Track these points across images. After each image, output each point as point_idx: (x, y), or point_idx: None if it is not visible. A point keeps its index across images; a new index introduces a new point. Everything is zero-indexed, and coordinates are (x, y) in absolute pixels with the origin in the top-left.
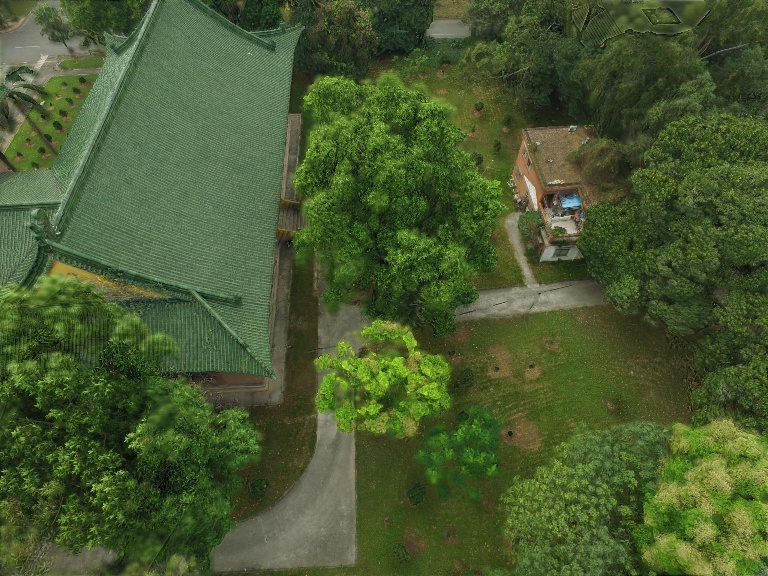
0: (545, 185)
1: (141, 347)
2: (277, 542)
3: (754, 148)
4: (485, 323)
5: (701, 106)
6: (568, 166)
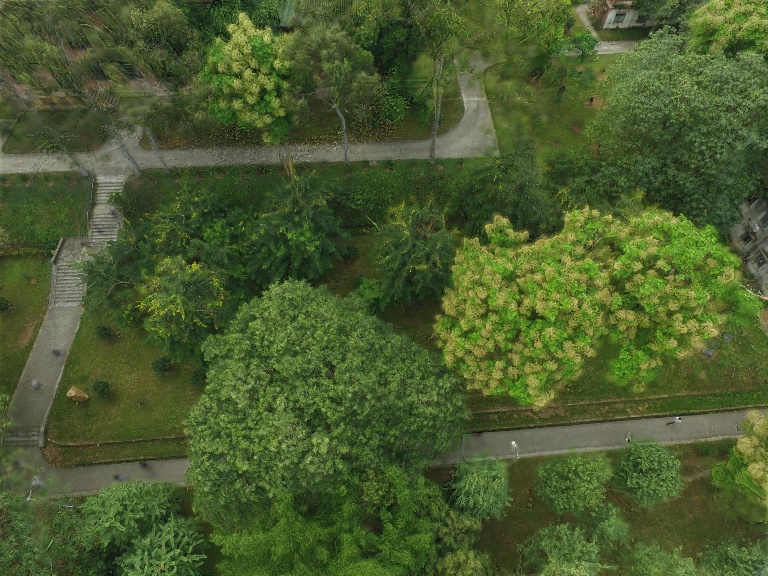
0: None
1: (380, 8)
2: (450, 148)
3: None
4: (568, 58)
5: None
6: None
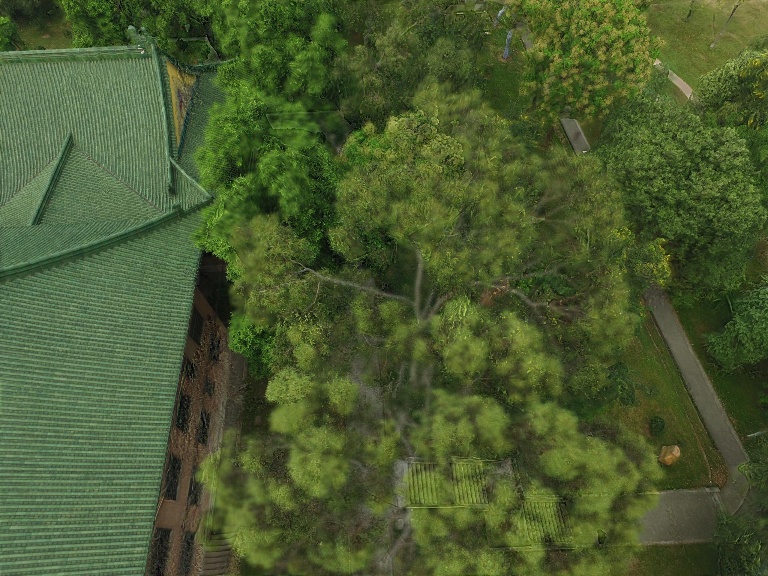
0: None
1: (226, 113)
2: None
3: None
4: None
5: None
6: None
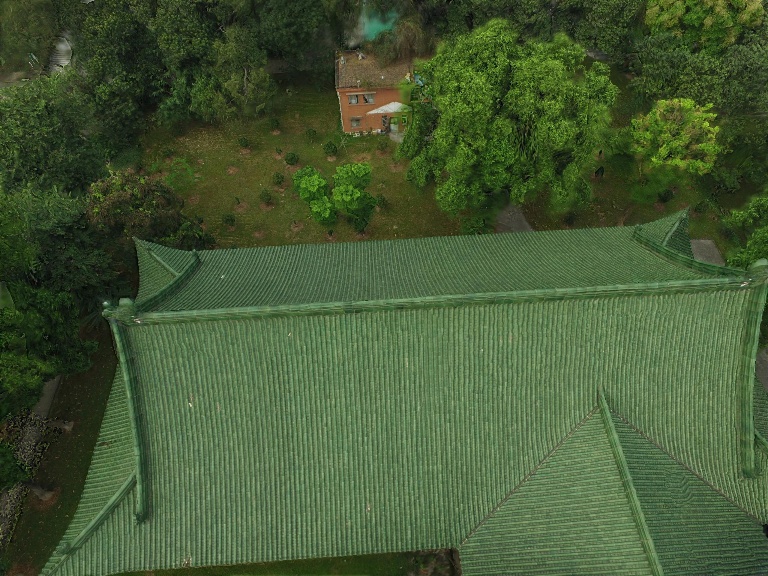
0: (411, 84)
1: None
2: None
3: None
4: None
5: None
6: (389, 69)
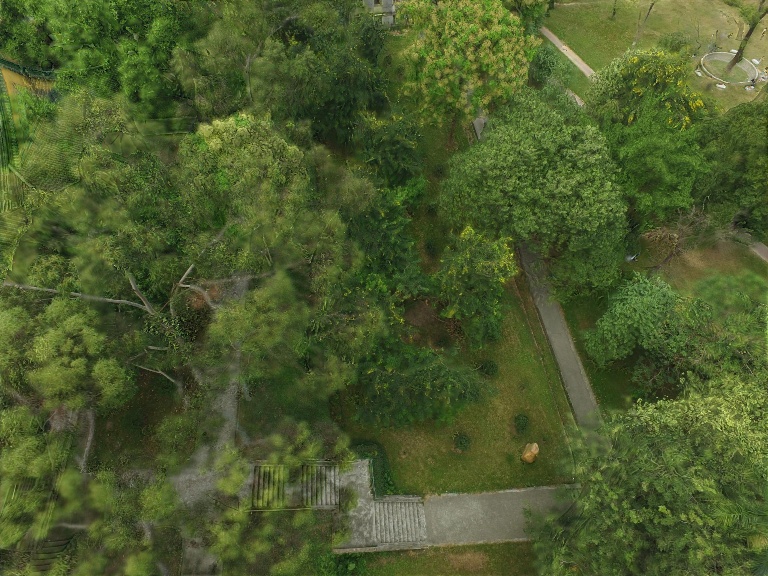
0: None
1: None
2: None
3: None
4: None
5: None
6: None
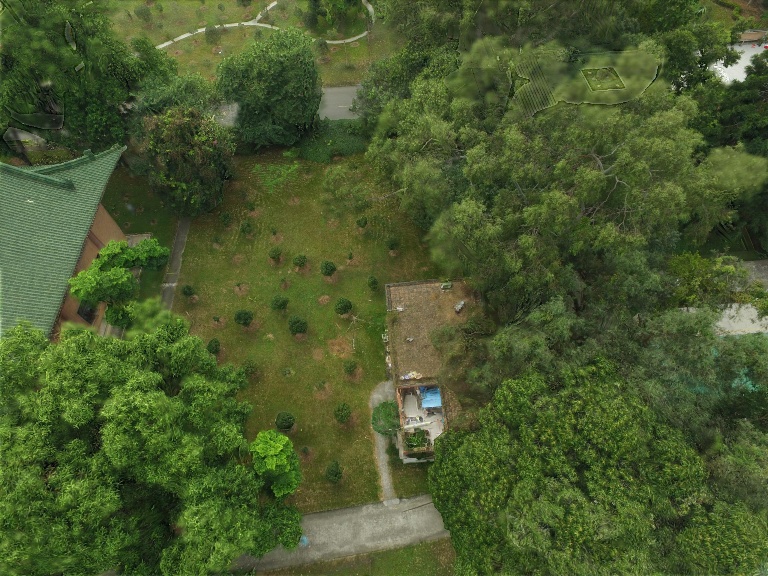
0: (397, 380)
1: None
2: None
3: (617, 447)
4: (317, 571)
5: (553, 352)
6: (431, 348)
